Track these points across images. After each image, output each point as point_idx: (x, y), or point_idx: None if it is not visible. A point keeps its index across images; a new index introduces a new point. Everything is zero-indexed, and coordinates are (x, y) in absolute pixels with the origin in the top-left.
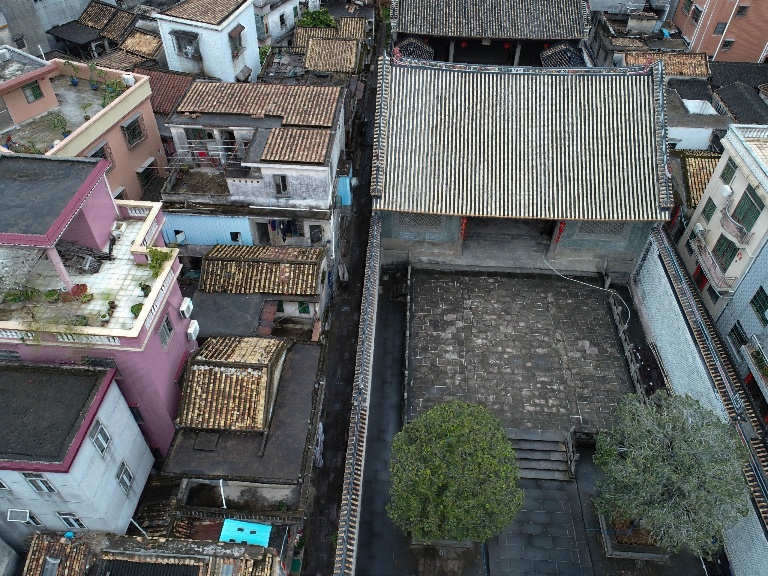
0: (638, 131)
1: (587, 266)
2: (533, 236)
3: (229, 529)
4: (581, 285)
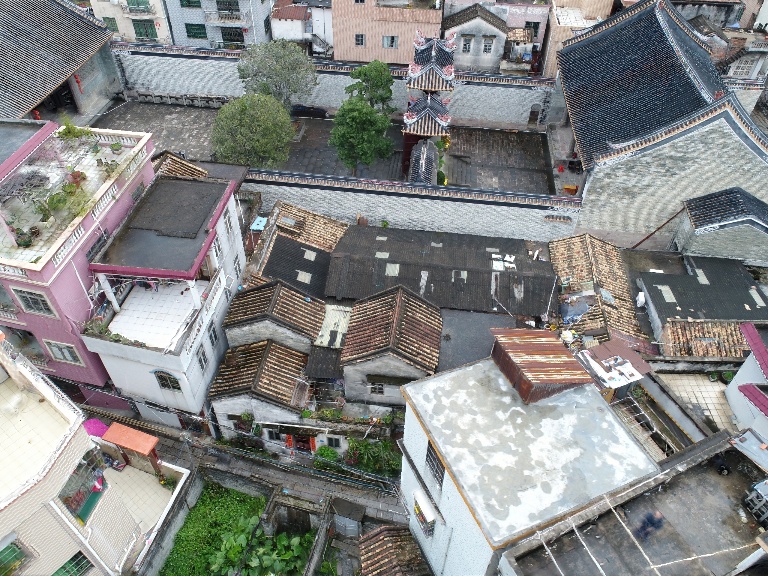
0: (37, 0)
1: (102, 102)
2: (54, 117)
3: (256, 227)
4: (117, 109)
